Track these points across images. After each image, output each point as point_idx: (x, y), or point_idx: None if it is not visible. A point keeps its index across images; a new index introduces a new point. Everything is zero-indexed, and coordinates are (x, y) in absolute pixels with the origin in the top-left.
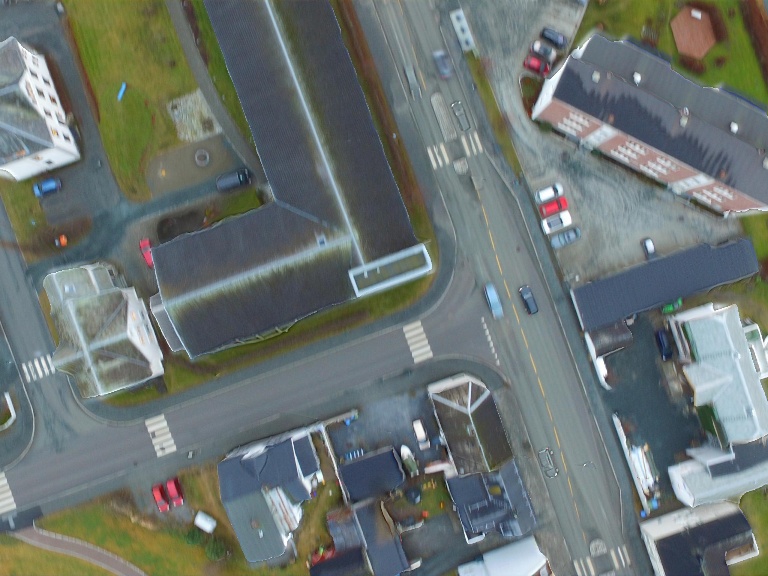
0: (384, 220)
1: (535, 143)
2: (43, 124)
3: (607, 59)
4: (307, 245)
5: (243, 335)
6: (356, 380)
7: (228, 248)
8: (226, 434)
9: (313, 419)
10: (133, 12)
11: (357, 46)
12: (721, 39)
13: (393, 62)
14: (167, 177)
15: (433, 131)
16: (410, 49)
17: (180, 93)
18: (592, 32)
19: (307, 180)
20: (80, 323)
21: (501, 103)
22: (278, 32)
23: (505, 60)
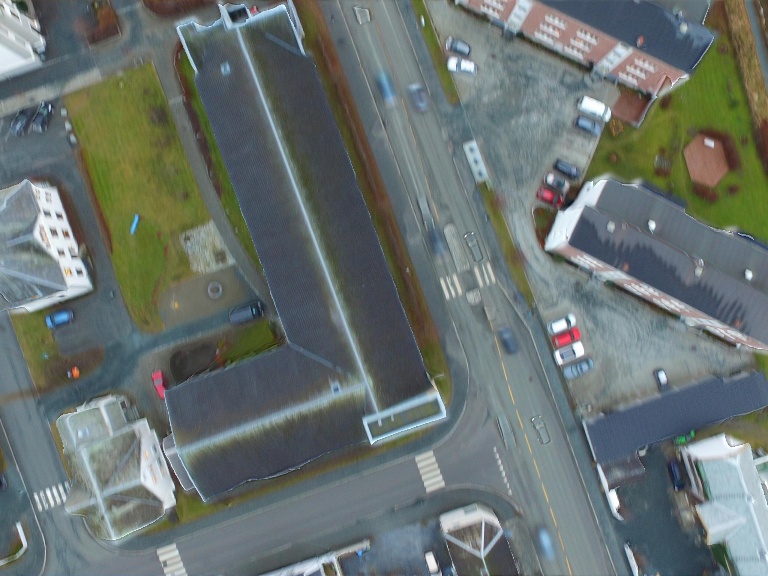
0: (398, 365)
1: (548, 273)
2: (57, 267)
3: (622, 206)
4: (321, 392)
5: (256, 477)
6: (368, 509)
7: (242, 393)
8: (238, 563)
9: (325, 549)
10: (146, 144)
11: (370, 178)
12: (734, 167)
13: (406, 193)
14: (180, 309)
15: (446, 262)
16: (423, 180)
17: (193, 224)
18: (605, 163)
19: (321, 326)
20: (94, 470)
21: (514, 234)
22: (293, 180)
23: (518, 191)
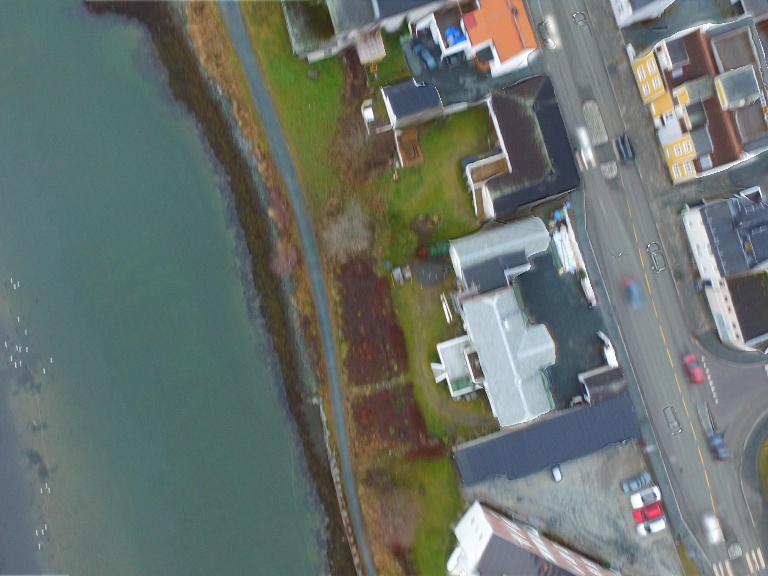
0: None
1: (662, 573)
2: None
3: None
4: None
5: None
6: None
7: None
8: None
9: None
10: None
11: None
12: None
13: None
14: None
15: None
16: None
17: None
18: None
19: None
20: None
21: None
22: None
23: None
